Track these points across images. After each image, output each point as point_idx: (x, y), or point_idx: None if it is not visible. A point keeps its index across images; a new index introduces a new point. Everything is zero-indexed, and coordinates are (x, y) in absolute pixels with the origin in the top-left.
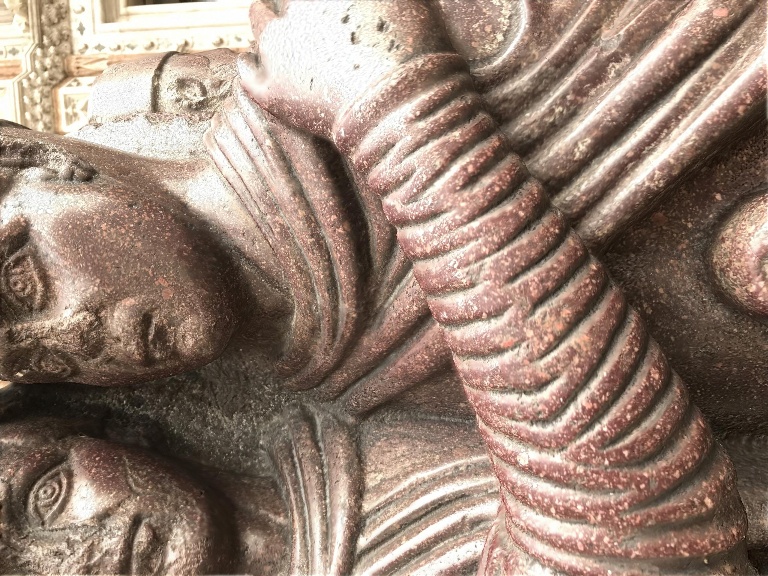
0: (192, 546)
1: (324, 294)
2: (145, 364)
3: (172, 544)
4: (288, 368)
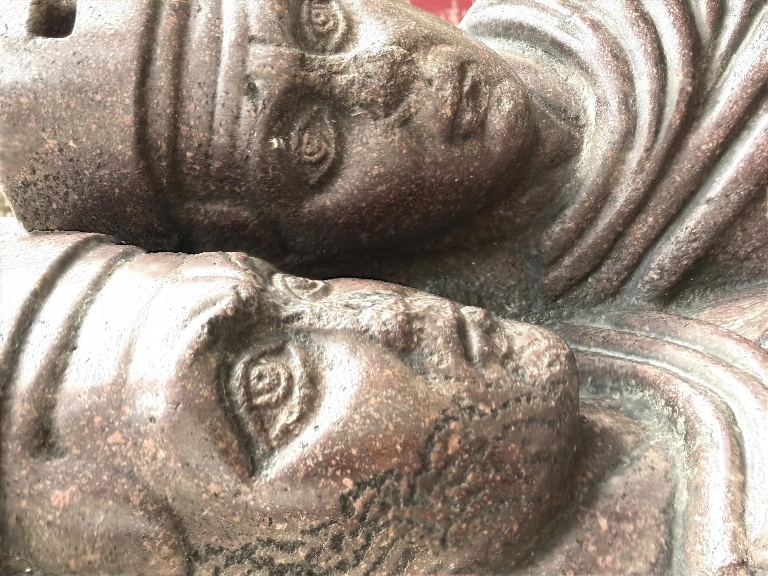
0: (547, 331)
1: (651, 71)
2: (446, 133)
3: (513, 331)
4: (571, 226)
